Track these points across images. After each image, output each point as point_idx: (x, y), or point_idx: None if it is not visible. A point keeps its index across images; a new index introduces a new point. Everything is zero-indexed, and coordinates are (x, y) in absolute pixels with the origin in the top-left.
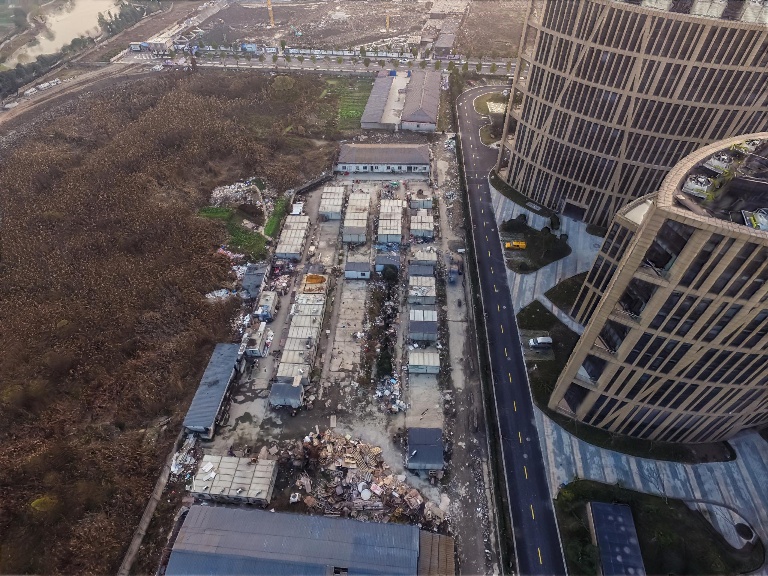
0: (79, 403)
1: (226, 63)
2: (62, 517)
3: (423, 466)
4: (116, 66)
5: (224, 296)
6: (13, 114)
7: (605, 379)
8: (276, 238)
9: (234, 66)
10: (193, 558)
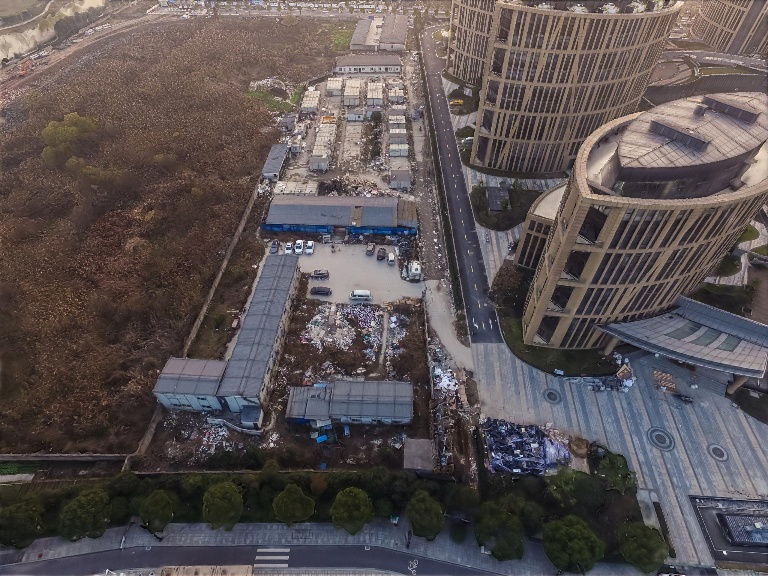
0: (195, 171)
1: (240, 13)
2: (205, 203)
3: (399, 184)
4: (151, 16)
5: None
6: (82, 45)
7: (493, 126)
8: (300, 102)
9: (247, 15)
10: (282, 206)
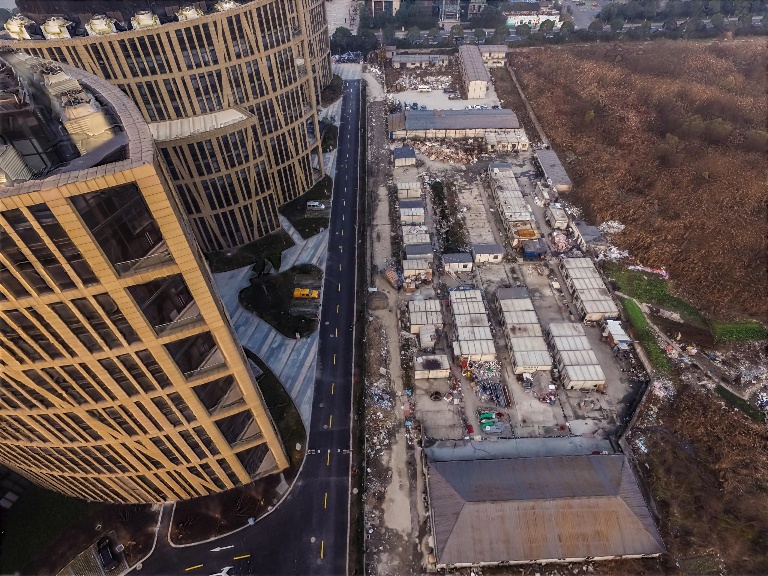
0: None
1: None
2: (580, 125)
3: None
4: None
5: (608, 229)
6: None
7: None
8: None
9: None
10: None
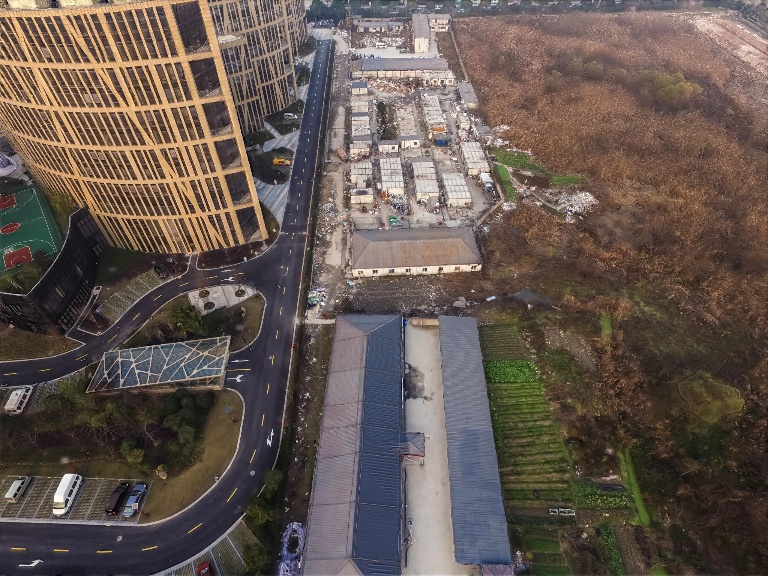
0: None
1: None
2: None
3: None
4: None
5: (499, 130)
6: None
7: None
8: None
9: None
10: None
